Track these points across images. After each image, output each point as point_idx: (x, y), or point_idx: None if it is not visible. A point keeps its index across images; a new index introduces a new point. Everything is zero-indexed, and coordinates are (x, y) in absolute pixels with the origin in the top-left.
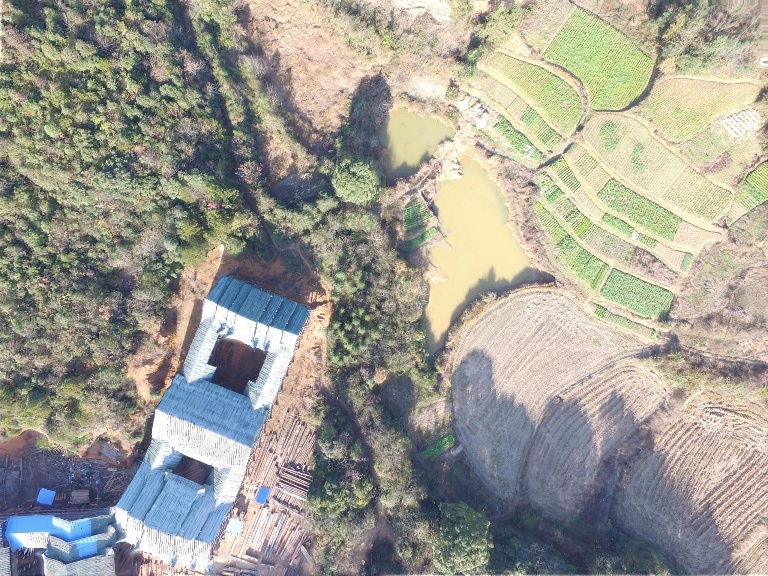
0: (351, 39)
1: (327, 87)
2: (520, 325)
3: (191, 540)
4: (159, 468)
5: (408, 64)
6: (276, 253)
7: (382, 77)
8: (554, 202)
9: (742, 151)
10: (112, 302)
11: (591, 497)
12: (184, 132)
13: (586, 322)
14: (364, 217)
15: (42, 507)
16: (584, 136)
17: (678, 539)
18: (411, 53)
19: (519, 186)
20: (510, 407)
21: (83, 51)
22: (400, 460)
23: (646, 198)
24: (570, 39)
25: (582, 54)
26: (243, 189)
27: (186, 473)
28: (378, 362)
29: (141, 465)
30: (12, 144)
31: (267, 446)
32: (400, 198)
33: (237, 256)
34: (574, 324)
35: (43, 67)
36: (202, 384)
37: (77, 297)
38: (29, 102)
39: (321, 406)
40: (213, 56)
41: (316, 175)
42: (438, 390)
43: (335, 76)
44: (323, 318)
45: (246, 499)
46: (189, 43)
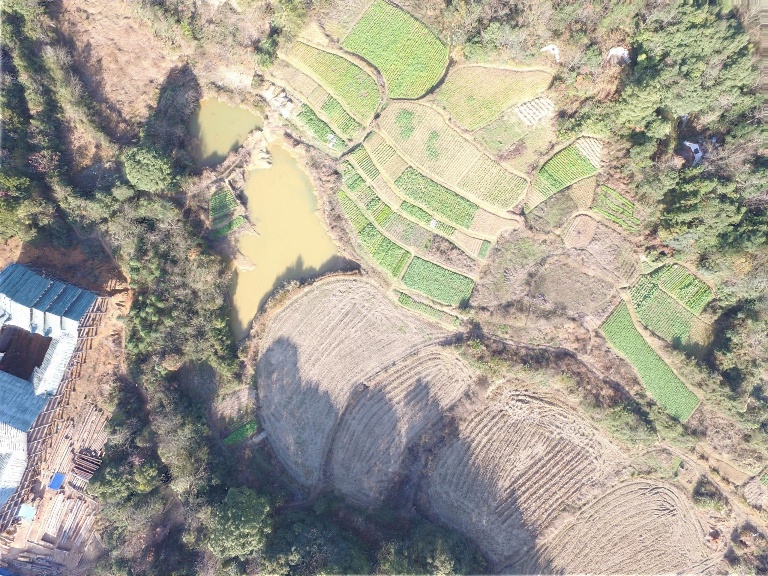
0: (157, 29)
1: (137, 77)
2: (326, 313)
3: None
4: None
5: (214, 54)
6: (76, 241)
7: (189, 67)
8: (355, 190)
9: (536, 139)
10: None
11: (395, 484)
12: None
13: (391, 310)
14: (155, 205)
15: None
16: (380, 124)
17: (483, 526)
18: (214, 43)
19: (324, 175)
20: (315, 394)
21: None
22: (187, 446)
23: (443, 186)
24: (369, 28)
25: (379, 43)
26: (37, 177)
27: None
28: (171, 349)
29: None
30: None
31: (64, 432)
32: (206, 187)
33: (36, 244)
34: (379, 312)
35: None
36: None
37: None
38: None
39: (116, 393)
40: (14, 46)
41: (119, 164)
42: (240, 377)
43: (145, 66)
44: (123, 306)
45: (42, 485)
46: None
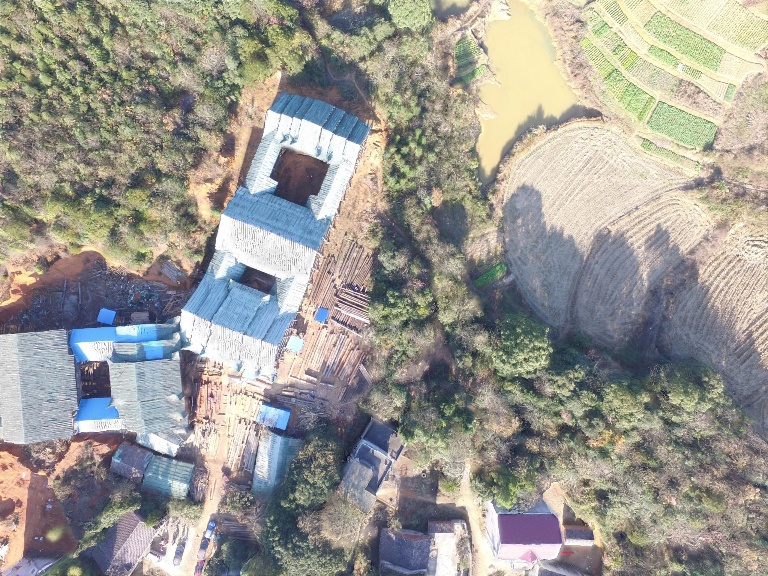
0: None
1: None
2: (569, 159)
3: (258, 340)
4: (223, 278)
5: None
6: (332, 82)
7: None
8: (602, 36)
9: None
10: (175, 116)
11: (639, 325)
12: None
13: (632, 156)
14: (421, 40)
15: (103, 325)
16: None
17: (722, 367)
18: None
19: (567, 24)
20: (560, 238)
21: None
22: None
23: (691, 30)
24: None
25: None
26: (302, 13)
27: (249, 285)
28: (435, 184)
29: (204, 277)
30: None
31: (325, 268)
32: (451, 34)
33: (294, 83)
34: (621, 158)
35: None
36: (265, 196)
37: (141, 108)
38: None
39: (378, 228)
40: None
41: (370, 8)
42: (491, 219)
43: None
44: (379, 146)
45: (305, 320)
46: None
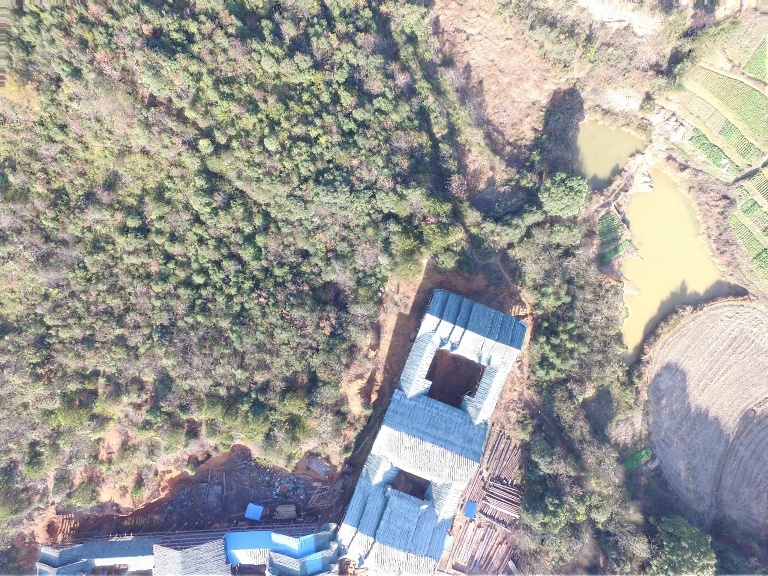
0: (547, 52)
1: (519, 99)
2: (713, 338)
3: (421, 556)
4: (379, 484)
5: (603, 77)
6: (478, 266)
7: (577, 90)
8: (751, 216)
9: None
10: (330, 316)
11: None
12: (399, 145)
13: None
14: (575, 231)
15: (252, 523)
16: None
17: None
18: (608, 66)
19: (713, 199)
20: (704, 420)
21: (301, 64)
22: None
23: None
24: None
25: None
26: (452, 202)
27: (404, 488)
28: (586, 376)
29: (359, 480)
30: (231, 157)
31: None
32: (595, 211)
33: (441, 269)
34: (767, 337)
35: (261, 80)
36: (421, 399)
37: (298, 312)
38: (249, 115)
39: (528, 420)
40: (416, 68)
41: (515, 188)
42: (636, 403)
43: (527, 88)
44: None
45: None
46: (395, 55)
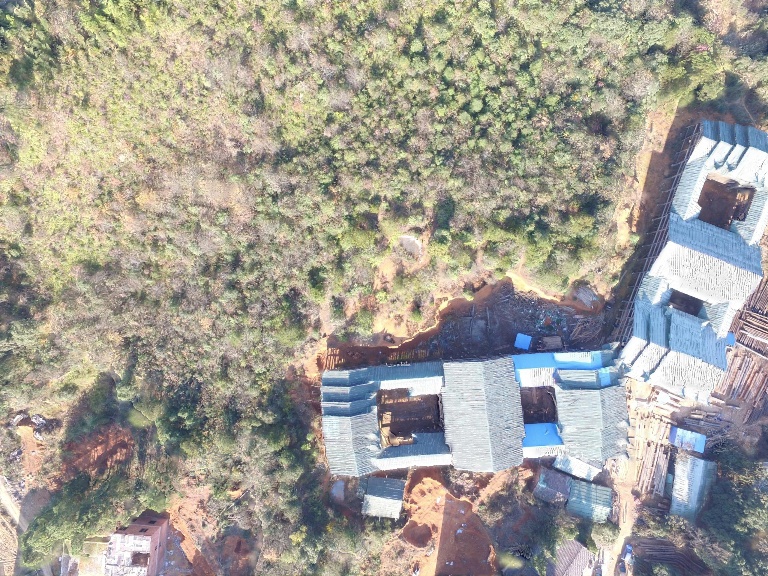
0: None
1: None
2: None
3: None
4: (657, 304)
5: None
6: (727, 106)
7: None
8: None
9: None
10: None
11: None
12: None
13: None
14: None
15: (524, 350)
16: None
17: None
18: None
19: None
20: None
21: None
22: None
23: None
24: None
25: None
26: None
27: None
28: None
29: (636, 302)
30: None
31: None
32: None
33: (693, 108)
34: None
35: None
36: (696, 222)
37: (580, 134)
38: None
39: None
40: None
41: (756, 33)
42: None
43: None
44: None
45: None
46: None
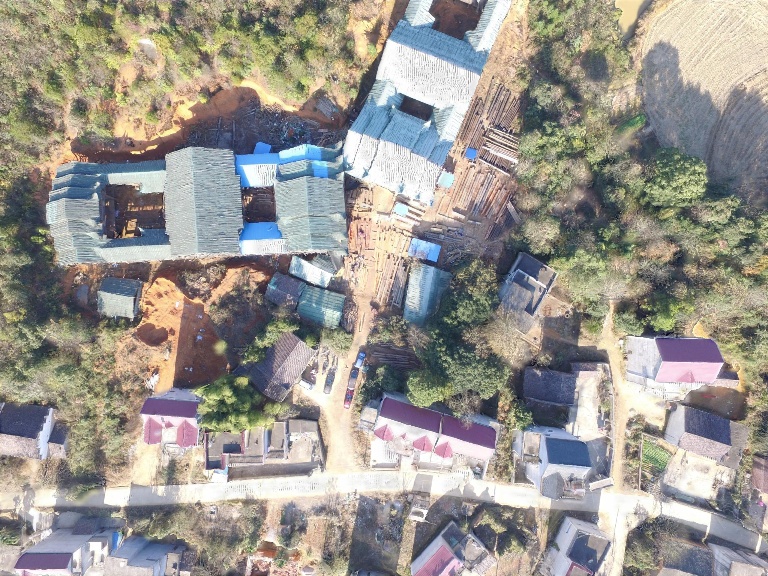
0: None
1: None
2: (705, 17)
3: (424, 160)
4: (383, 107)
5: None
6: None
7: None
8: None
9: None
10: None
11: None
12: None
13: (767, 16)
14: None
15: None
16: None
17: None
18: None
19: None
20: (697, 93)
21: None
22: None
23: None
24: None
25: None
26: None
27: None
28: None
29: (364, 106)
30: None
31: (473, 110)
32: None
33: None
34: (756, 17)
35: None
36: (425, 29)
37: None
38: None
39: (526, 72)
40: None
41: None
42: None
43: None
44: None
45: (454, 159)
46: None
